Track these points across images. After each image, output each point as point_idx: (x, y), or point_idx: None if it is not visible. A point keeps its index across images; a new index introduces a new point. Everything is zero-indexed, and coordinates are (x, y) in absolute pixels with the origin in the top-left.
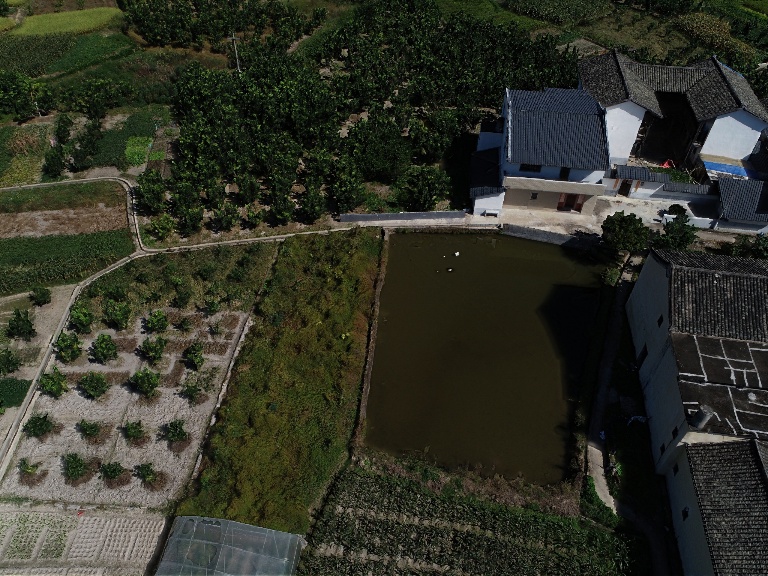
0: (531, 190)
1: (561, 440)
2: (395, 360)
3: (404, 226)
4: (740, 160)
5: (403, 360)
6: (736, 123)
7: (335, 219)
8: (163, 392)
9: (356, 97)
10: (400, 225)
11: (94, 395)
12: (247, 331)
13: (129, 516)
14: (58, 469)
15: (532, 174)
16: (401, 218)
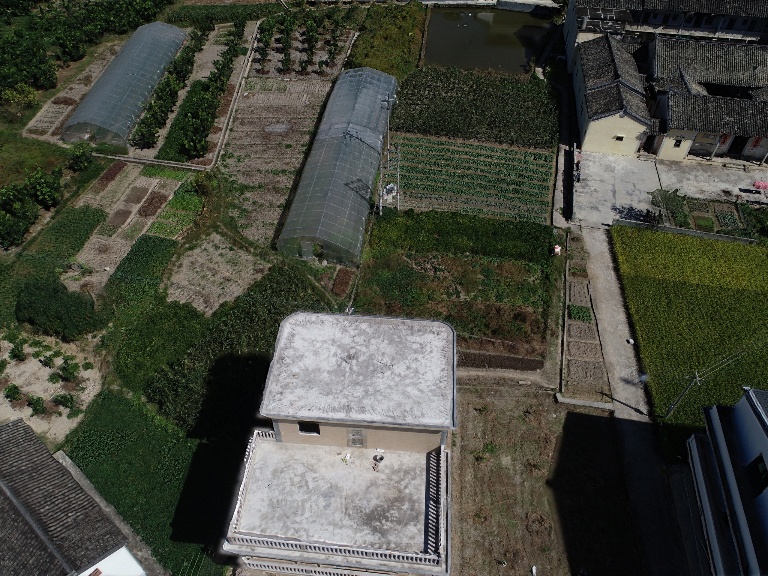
0: None
1: (523, 68)
2: (437, 47)
3: (439, 3)
4: None
5: (441, 47)
6: None
7: (398, 1)
8: (318, 53)
9: None
10: None
11: (286, 46)
12: (356, 36)
13: (314, 82)
14: (274, 71)
15: None
16: (437, 0)
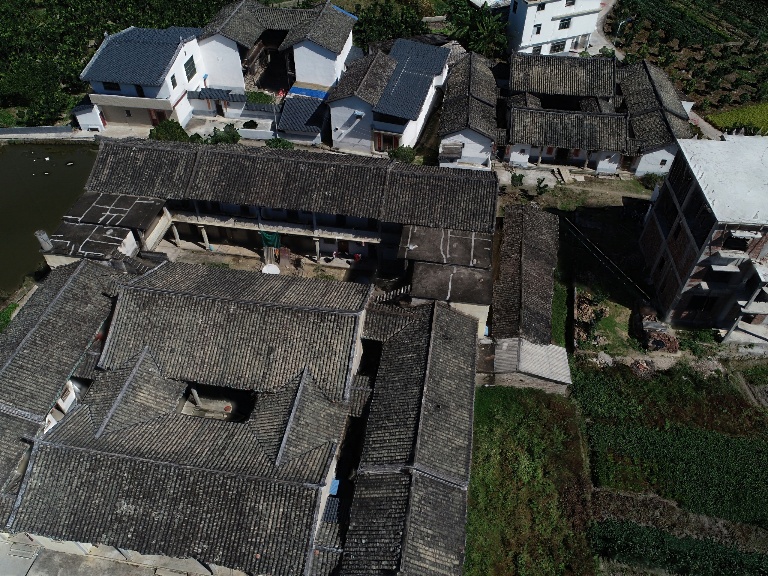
0: (116, 106)
1: None
2: None
3: (16, 138)
4: (330, 87)
5: None
6: (311, 52)
7: None
8: None
9: (43, 41)
10: (14, 138)
11: None
12: None
13: None
14: None
15: (114, 92)
16: (17, 132)
